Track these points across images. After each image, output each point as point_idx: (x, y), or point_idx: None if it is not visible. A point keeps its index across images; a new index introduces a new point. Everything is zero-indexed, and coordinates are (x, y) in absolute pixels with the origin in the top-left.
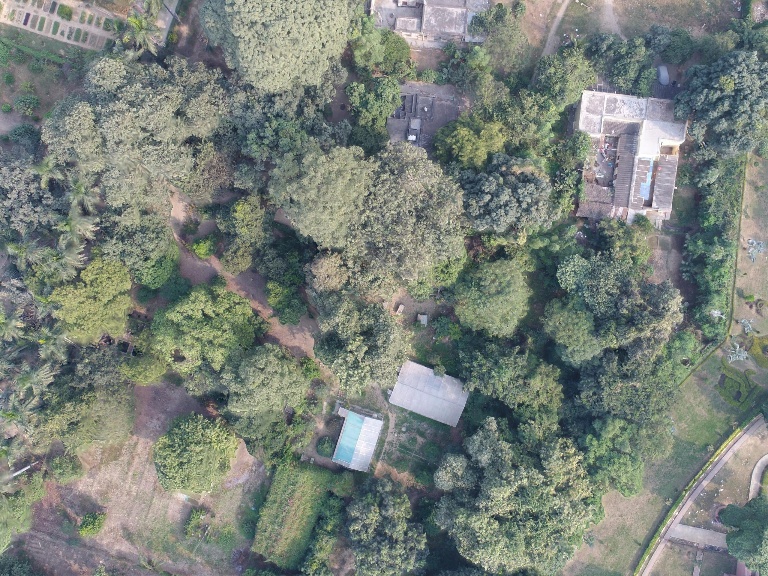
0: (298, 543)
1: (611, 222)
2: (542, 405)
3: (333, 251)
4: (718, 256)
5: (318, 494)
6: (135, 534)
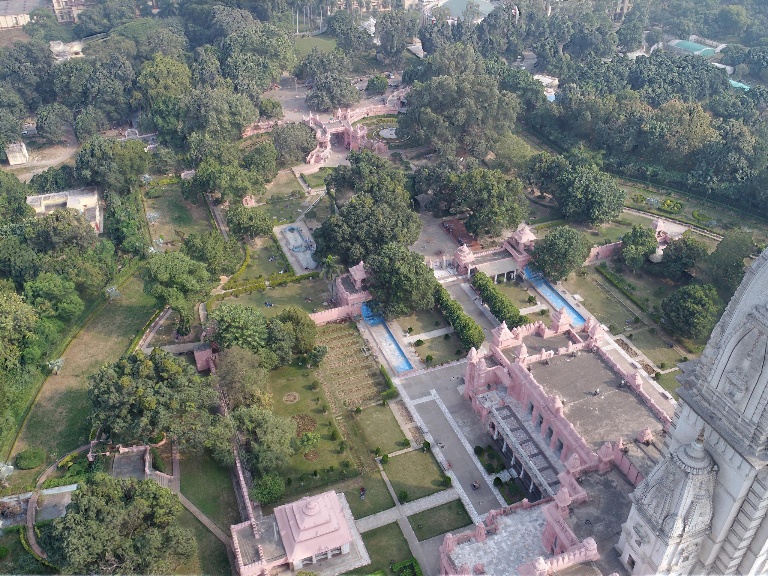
0: None
1: None
2: None
3: None
4: (121, 216)
5: None
6: None
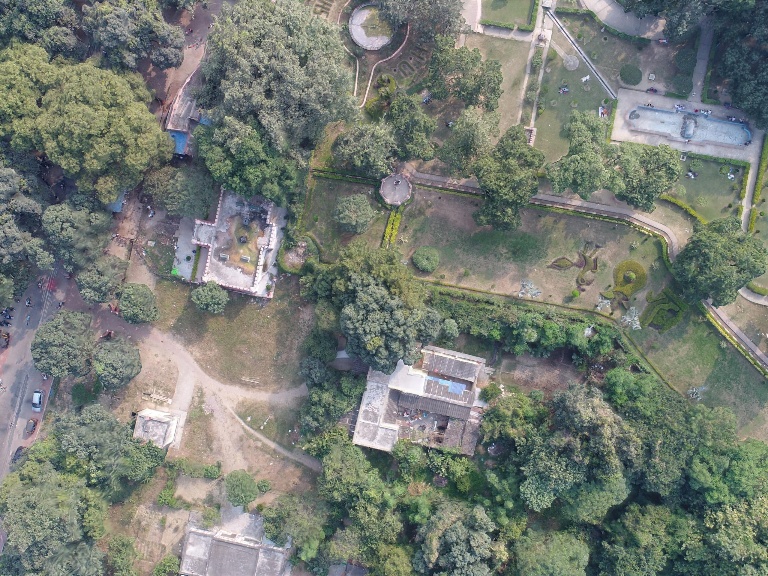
0: None
1: (486, 432)
2: (666, 528)
3: None
4: (534, 337)
5: None
6: None
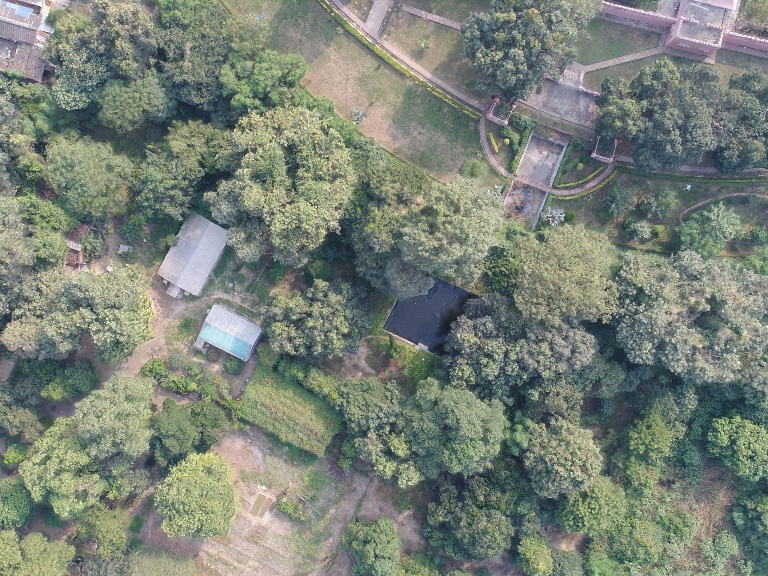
0: (320, 409)
1: None
2: None
3: (6, 327)
4: None
5: (273, 381)
6: (297, 570)
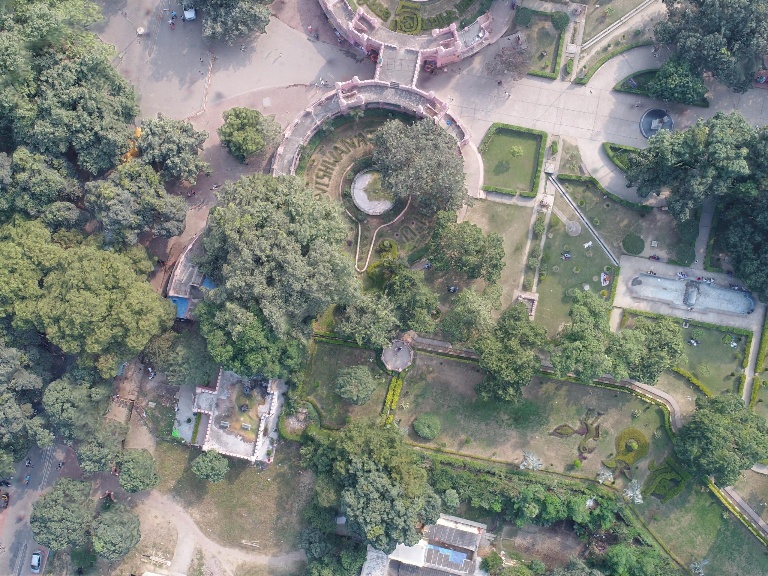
0: None
1: None
2: None
3: None
4: None
5: None
6: None
